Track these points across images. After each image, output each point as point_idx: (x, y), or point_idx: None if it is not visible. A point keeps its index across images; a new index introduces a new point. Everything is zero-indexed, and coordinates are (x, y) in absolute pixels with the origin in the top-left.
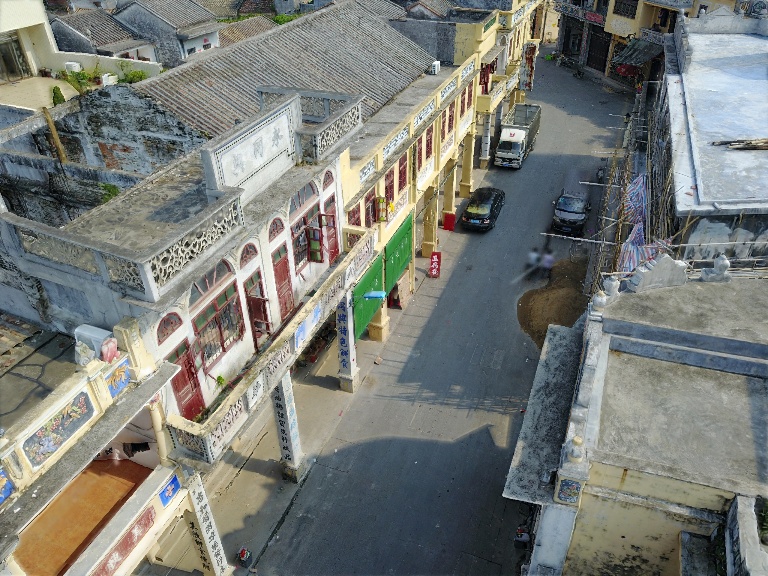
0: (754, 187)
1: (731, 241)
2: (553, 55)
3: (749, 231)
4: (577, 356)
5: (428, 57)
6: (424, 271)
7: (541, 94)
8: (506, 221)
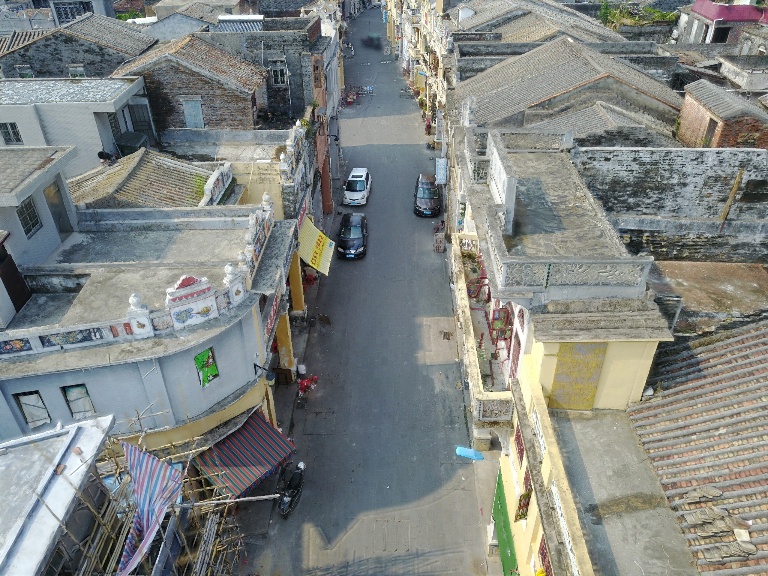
0: None
1: None
2: None
3: None
4: (257, 274)
5: None
6: None
7: None
8: None
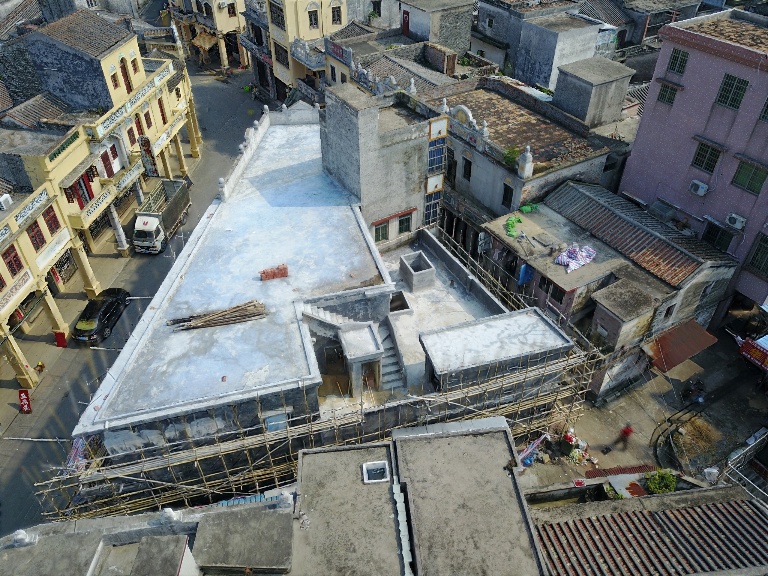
0: (158, 389)
1: (144, 438)
2: (250, 87)
3: (154, 430)
4: None
5: (2, 187)
6: (18, 407)
7: (222, 142)
8: (124, 326)
